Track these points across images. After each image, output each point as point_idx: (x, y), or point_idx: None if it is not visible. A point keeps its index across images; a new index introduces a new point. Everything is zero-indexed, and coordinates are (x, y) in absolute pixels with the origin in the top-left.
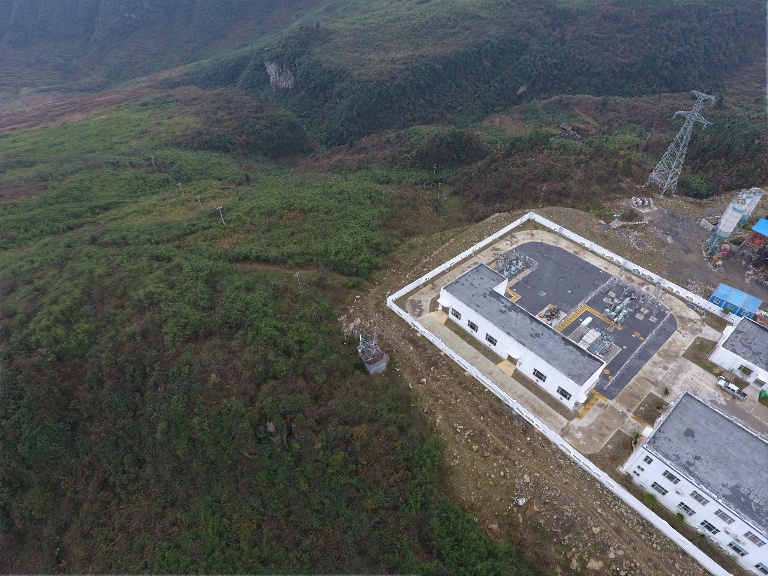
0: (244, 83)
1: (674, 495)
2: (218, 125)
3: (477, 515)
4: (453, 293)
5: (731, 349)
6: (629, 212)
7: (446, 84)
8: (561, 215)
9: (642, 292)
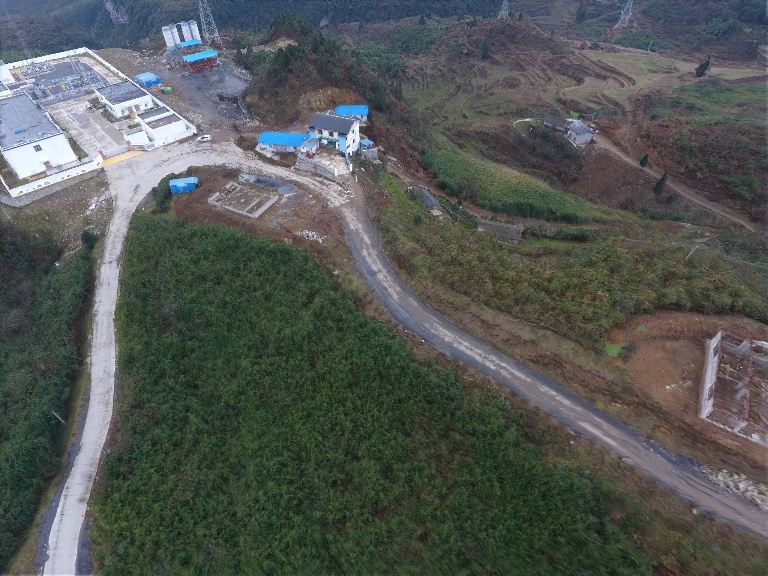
0: (99, 23)
1: None
2: (14, 39)
3: None
4: None
5: None
6: None
7: (249, 16)
8: (111, 51)
9: None
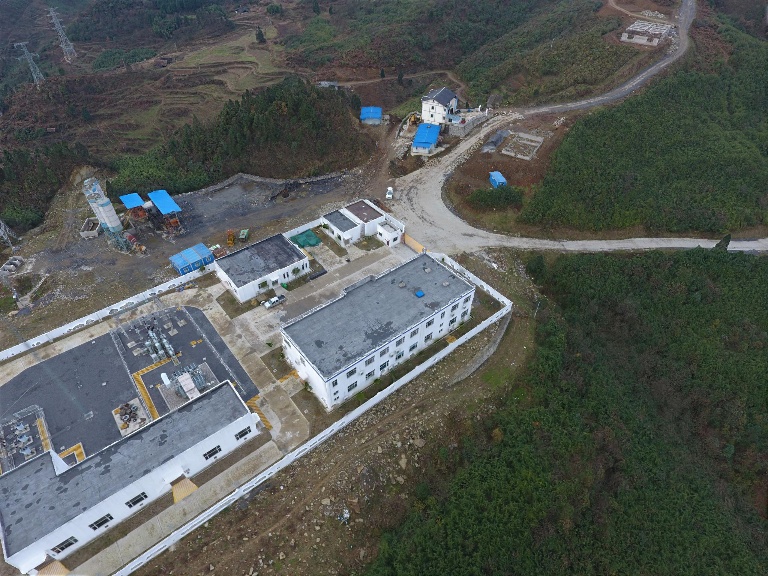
0: None
1: (361, 378)
2: None
3: (349, 571)
4: (28, 541)
5: (242, 283)
6: (17, 283)
7: None
8: None
9: (146, 318)
